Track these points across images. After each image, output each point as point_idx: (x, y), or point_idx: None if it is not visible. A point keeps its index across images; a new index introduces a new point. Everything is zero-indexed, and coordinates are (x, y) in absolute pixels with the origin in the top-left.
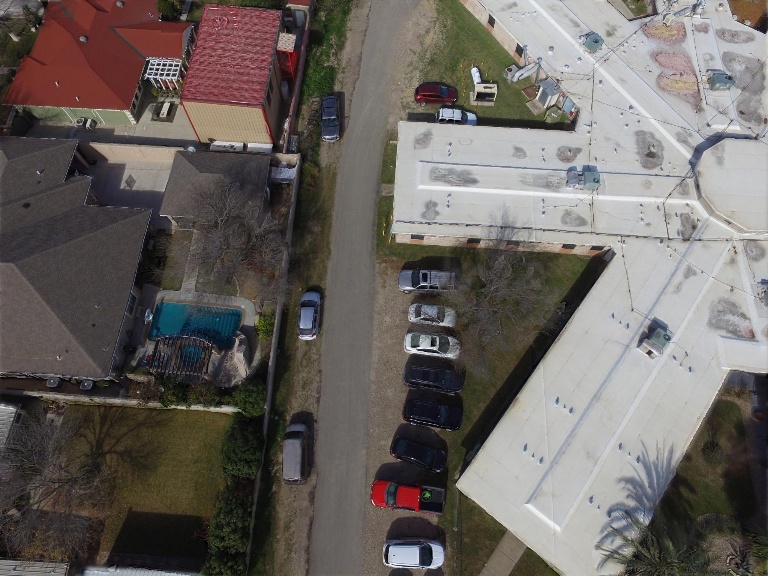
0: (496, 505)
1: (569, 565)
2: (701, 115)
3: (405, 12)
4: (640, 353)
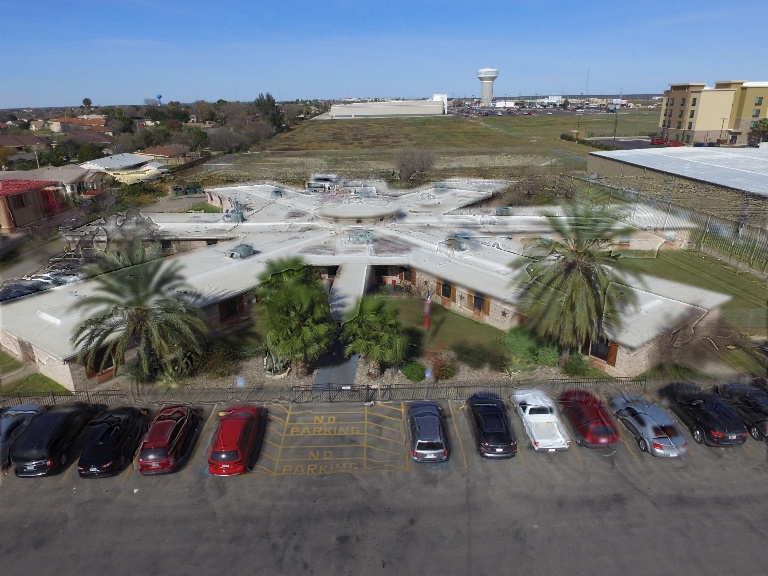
0: (3, 316)
1: (46, 339)
2: None
3: (169, 206)
4: (226, 259)
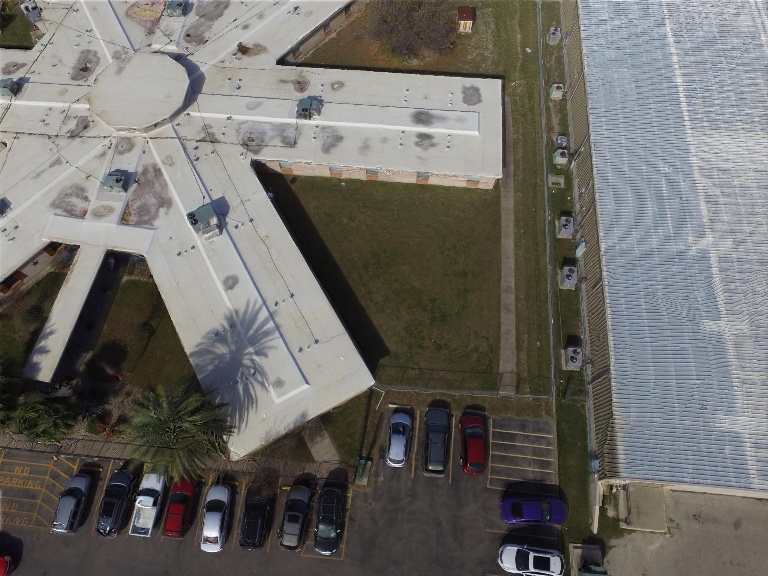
0: None
1: None
2: (149, 37)
3: None
4: None
